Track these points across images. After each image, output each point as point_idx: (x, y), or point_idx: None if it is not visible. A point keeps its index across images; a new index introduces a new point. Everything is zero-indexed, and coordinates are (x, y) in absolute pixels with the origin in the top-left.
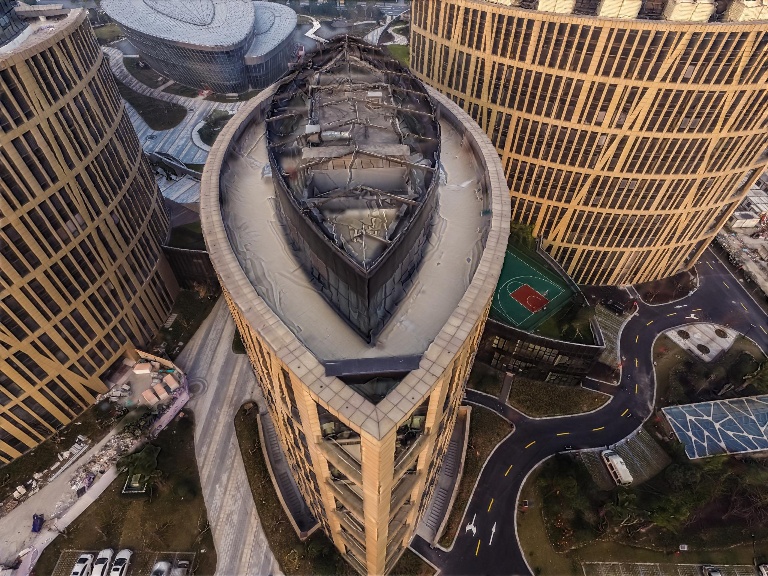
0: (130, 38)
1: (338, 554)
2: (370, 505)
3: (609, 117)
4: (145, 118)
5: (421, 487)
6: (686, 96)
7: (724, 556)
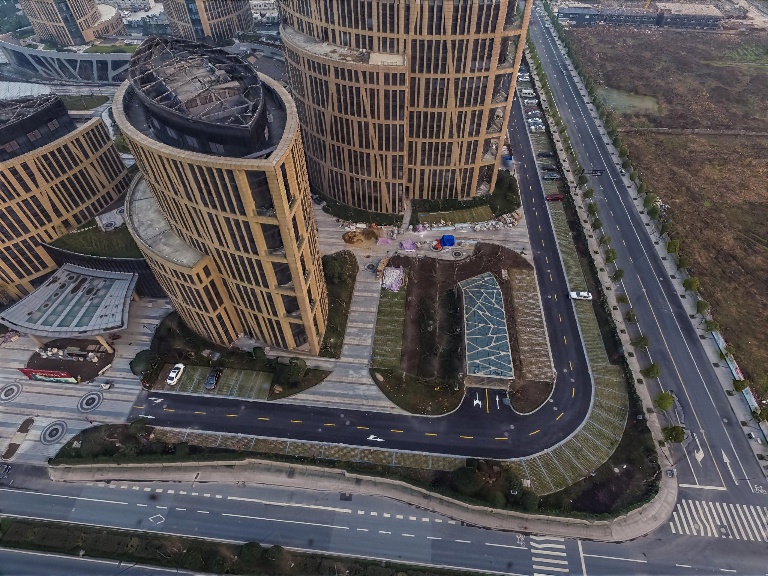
0: None
1: None
2: None
3: None
4: None
5: None
6: None
7: None
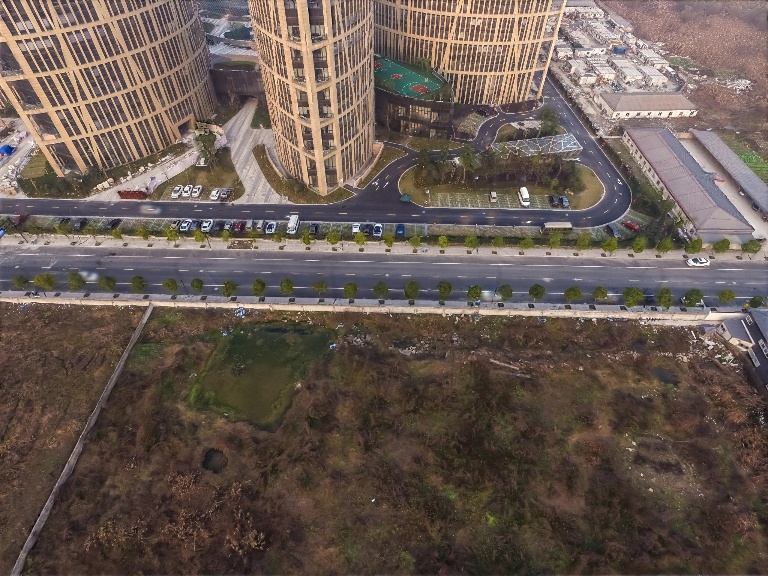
0: None
1: (305, 184)
2: (306, 62)
3: None
4: None
5: (335, 102)
6: None
7: (503, 192)
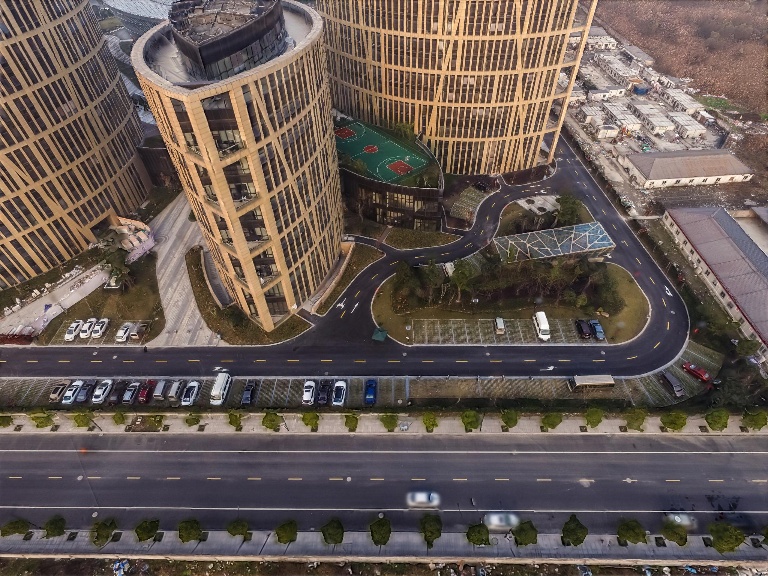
0: (123, 21)
1: (245, 314)
2: (214, 183)
3: (441, 26)
4: (135, 83)
5: (271, 222)
6: (488, 6)
7: (512, 314)
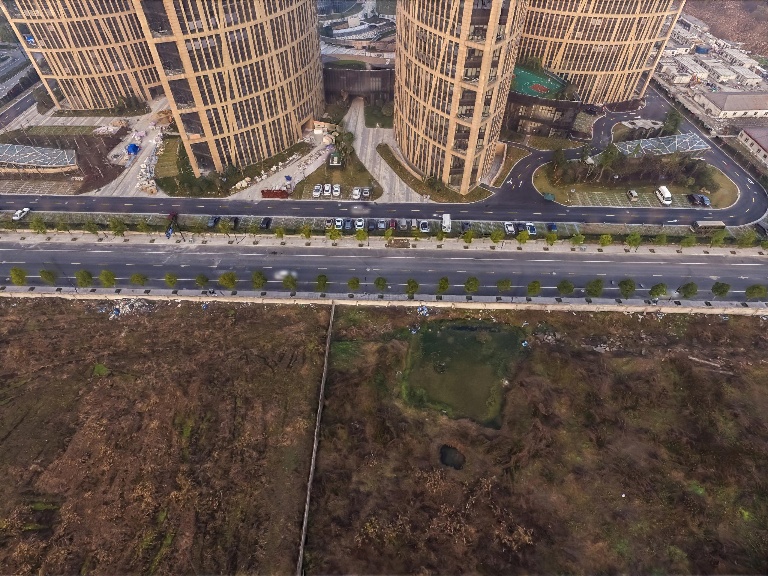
0: None
1: (444, 183)
2: (485, 61)
3: None
4: None
5: None
6: None
7: (639, 190)
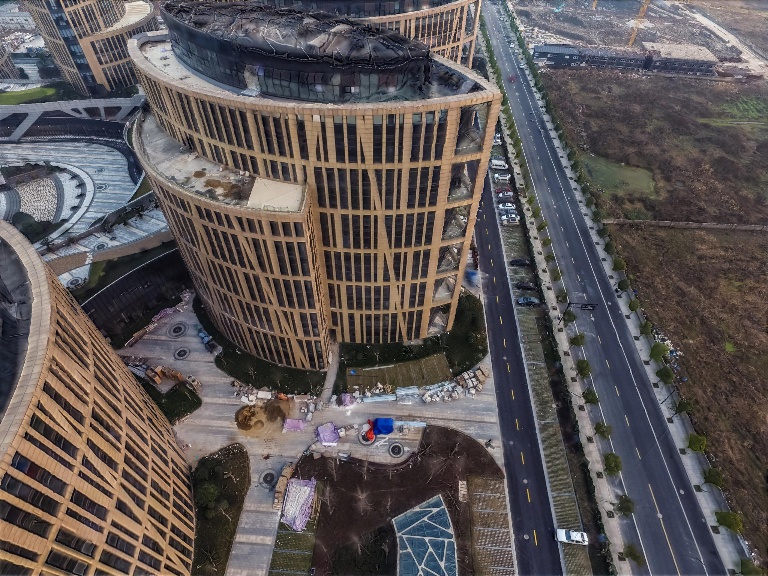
0: None
1: None
2: None
3: None
4: None
5: None
6: None
7: None
